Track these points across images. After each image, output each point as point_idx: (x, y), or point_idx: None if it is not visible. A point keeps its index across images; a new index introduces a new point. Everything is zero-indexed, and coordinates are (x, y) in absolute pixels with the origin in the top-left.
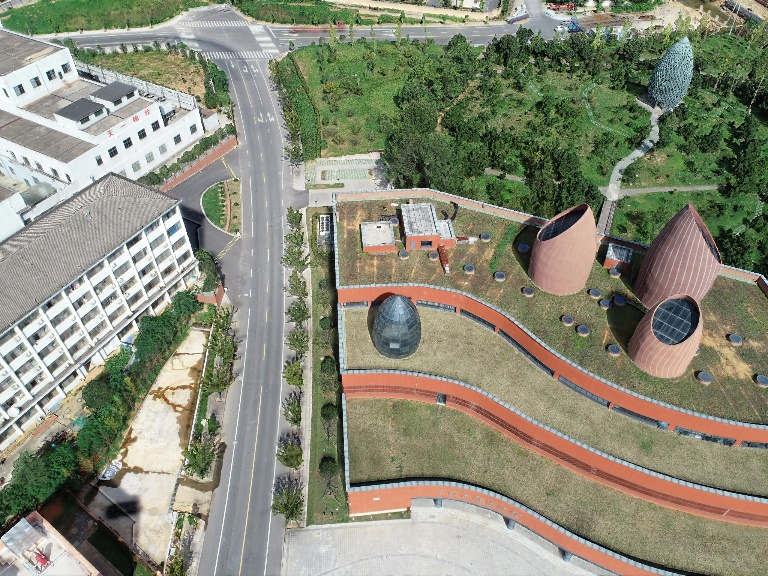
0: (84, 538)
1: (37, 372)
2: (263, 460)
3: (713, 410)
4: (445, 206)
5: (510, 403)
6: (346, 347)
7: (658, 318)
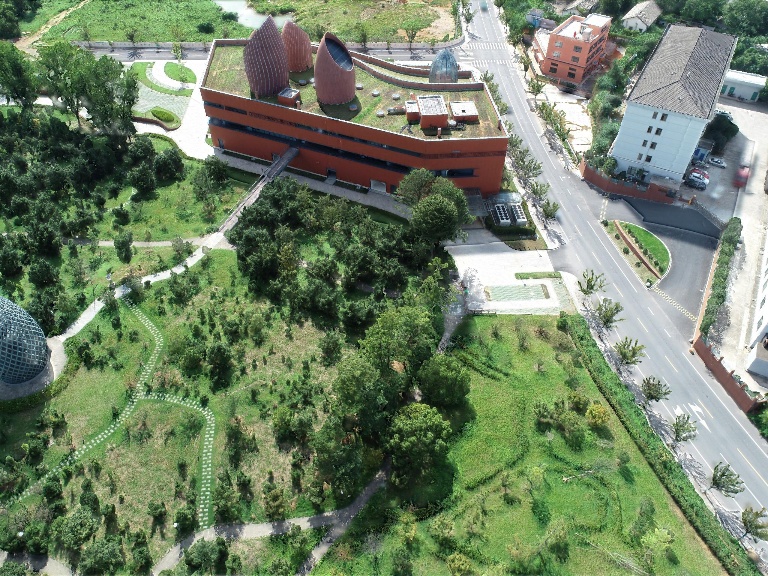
0: (579, 87)
1: None
2: None
3: None
4: None
5: (381, 68)
6: None
7: None
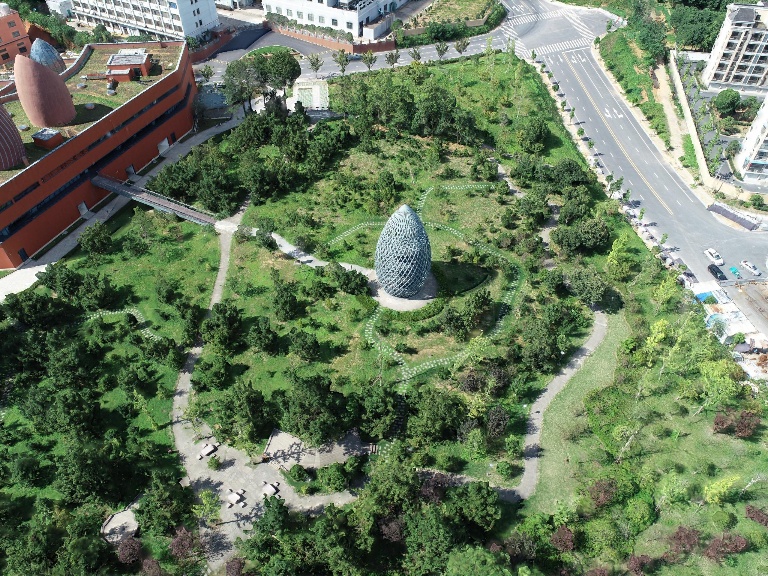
0: None
1: (103, 6)
2: None
3: None
4: None
5: None
6: None
7: None
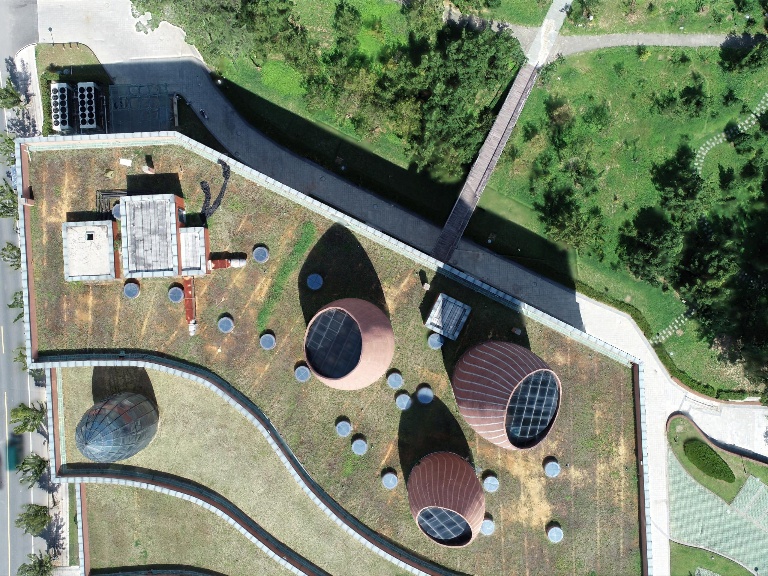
0: None
1: None
2: (18, 491)
3: (479, 568)
4: (208, 169)
5: (259, 519)
6: (64, 429)
7: (428, 509)
